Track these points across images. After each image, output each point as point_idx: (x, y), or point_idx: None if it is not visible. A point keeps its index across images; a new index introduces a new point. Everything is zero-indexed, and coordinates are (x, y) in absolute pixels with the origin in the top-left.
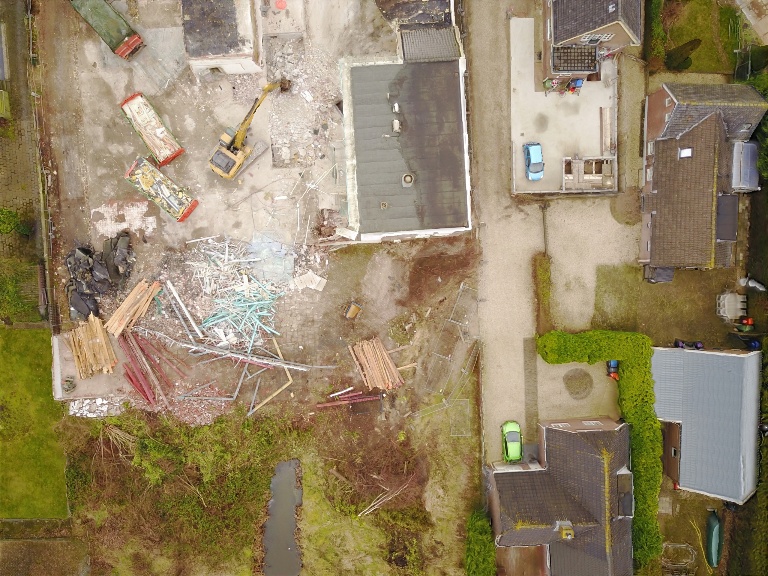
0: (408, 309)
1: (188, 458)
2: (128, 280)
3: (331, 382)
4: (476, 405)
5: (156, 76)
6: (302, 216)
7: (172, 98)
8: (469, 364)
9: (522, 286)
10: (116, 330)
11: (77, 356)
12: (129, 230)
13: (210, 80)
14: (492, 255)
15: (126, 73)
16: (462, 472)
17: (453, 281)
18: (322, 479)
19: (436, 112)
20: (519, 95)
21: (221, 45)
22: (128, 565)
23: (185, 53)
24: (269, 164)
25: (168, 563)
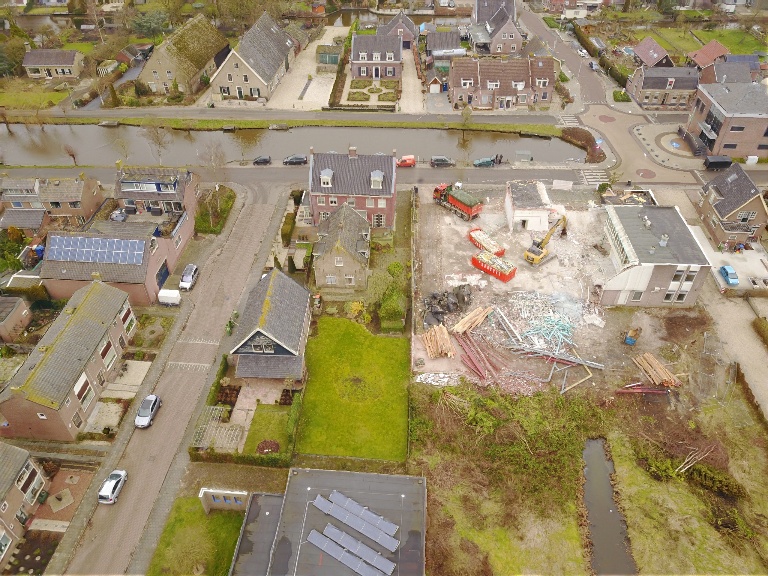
0: (670, 343)
1: (515, 416)
2: (469, 307)
3: (623, 379)
4: (749, 403)
5: (485, 229)
6: (584, 286)
7: (495, 237)
8: (731, 378)
9: (751, 338)
10: (461, 330)
11: (428, 346)
12: (470, 285)
13: (519, 229)
14: (720, 321)
15: (468, 227)
16: (758, 453)
17: (698, 331)
18: (631, 450)
19: (669, 223)
20: (705, 252)
21: (534, 205)
22: (458, 505)
23: (514, 206)
24: (557, 264)
25: (496, 507)
